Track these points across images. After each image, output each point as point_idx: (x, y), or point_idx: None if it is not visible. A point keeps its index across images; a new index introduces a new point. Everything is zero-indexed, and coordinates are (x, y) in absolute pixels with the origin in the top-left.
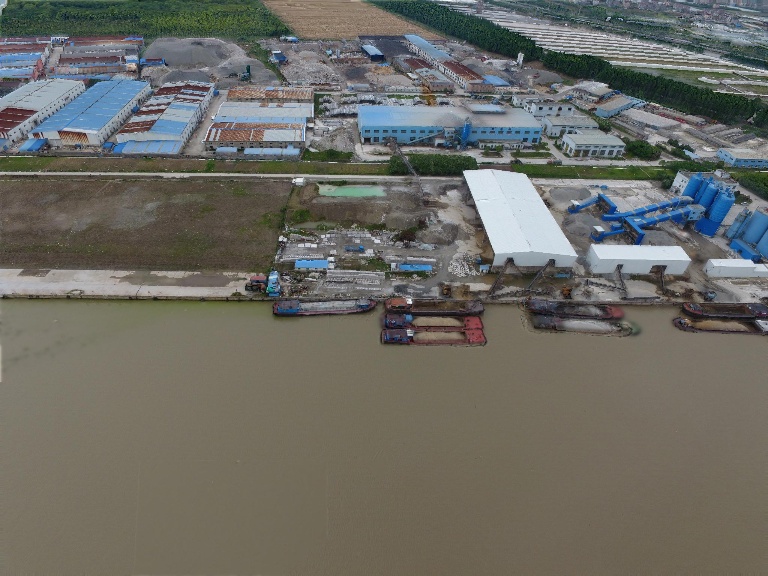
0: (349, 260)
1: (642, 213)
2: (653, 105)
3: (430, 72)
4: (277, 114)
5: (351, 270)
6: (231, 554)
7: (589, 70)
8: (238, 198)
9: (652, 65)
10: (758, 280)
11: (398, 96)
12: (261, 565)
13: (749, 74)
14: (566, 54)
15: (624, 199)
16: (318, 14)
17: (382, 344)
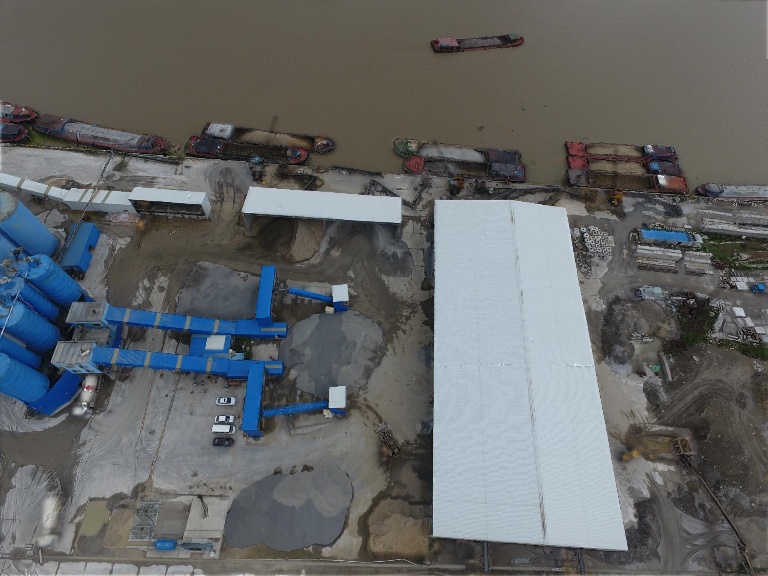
0: (765, 259)
1: None
2: None
3: None
4: None
5: None
6: (727, 4)
7: None
8: None
9: None
10: None
11: None
12: (708, 4)
13: None
14: None
15: (151, 475)
16: None
17: None
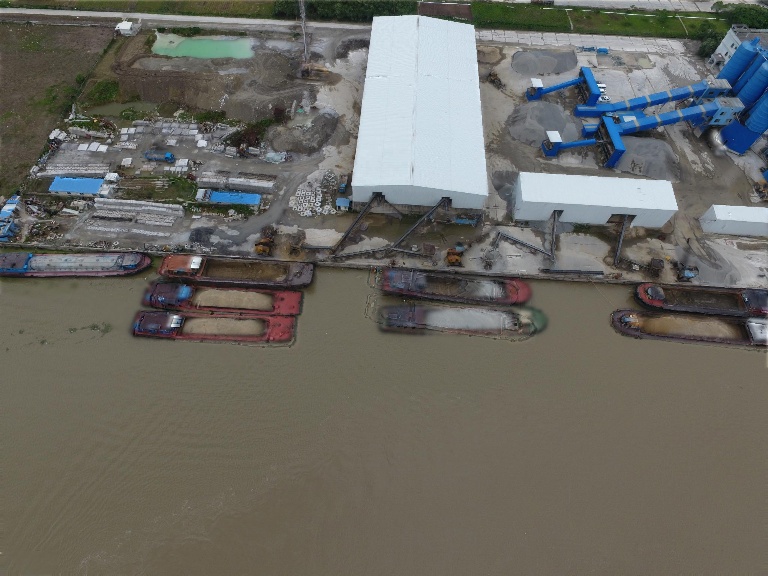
0: (140, 179)
1: (640, 106)
2: None
3: None
4: None
5: (132, 199)
6: None
7: None
8: (25, 55)
9: None
10: None
11: None
12: None
13: None
14: None
15: (627, 75)
16: None
17: (134, 336)
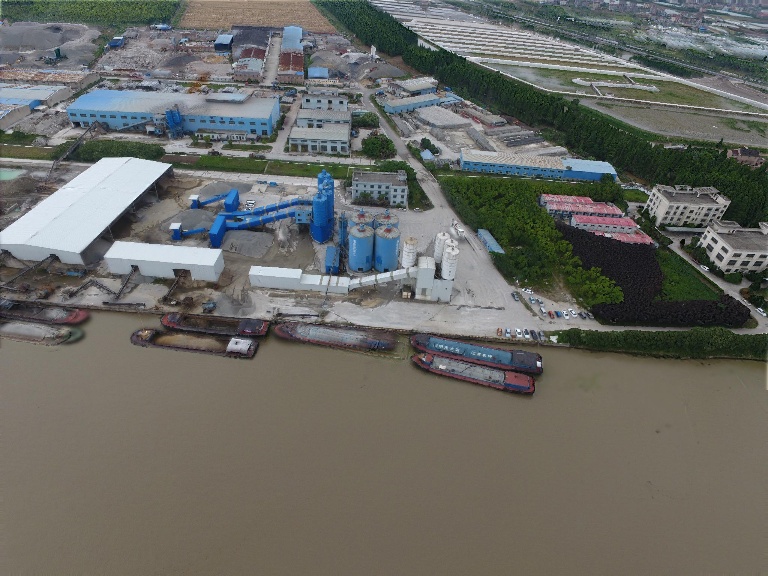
0: None
1: (260, 212)
2: (465, 103)
3: (249, 61)
4: (11, 95)
5: None
6: None
7: (433, 65)
8: None
9: (535, 64)
10: (307, 294)
11: (190, 84)
12: None
13: (642, 77)
14: (423, 49)
15: None
16: (234, 5)
17: None
